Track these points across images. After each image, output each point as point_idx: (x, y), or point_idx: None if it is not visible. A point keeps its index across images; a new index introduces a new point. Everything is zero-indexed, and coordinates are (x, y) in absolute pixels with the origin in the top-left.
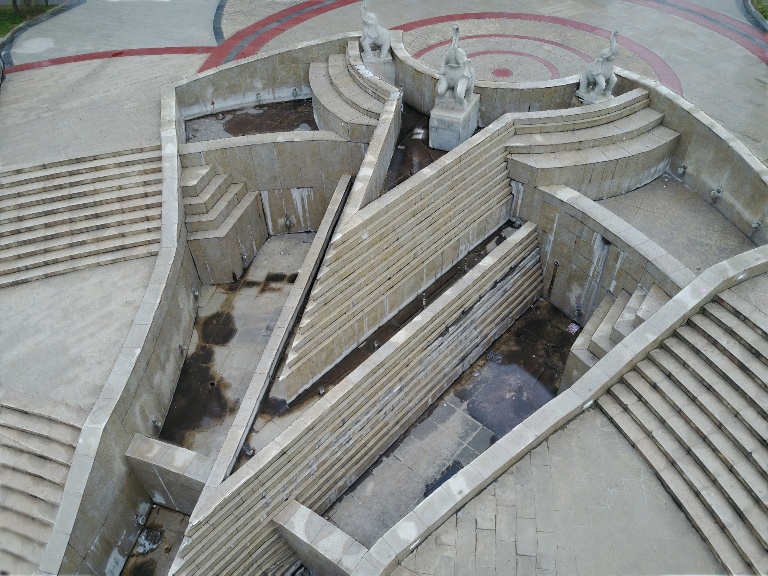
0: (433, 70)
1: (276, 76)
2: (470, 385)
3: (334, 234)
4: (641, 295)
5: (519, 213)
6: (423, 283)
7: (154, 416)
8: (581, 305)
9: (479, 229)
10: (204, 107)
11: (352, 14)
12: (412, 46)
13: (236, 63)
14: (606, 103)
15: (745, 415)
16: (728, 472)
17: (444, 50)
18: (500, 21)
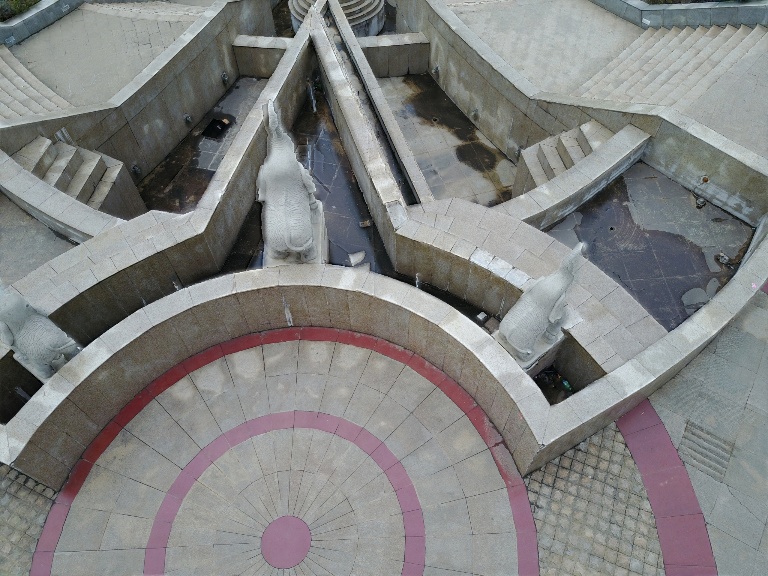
0: (368, 289)
1: None
2: None
3: None
4: None
5: None
6: None
7: None
8: None
9: None
10: None
11: None
12: None
13: (766, 249)
14: None
15: None
16: (7, 92)
17: None
18: None
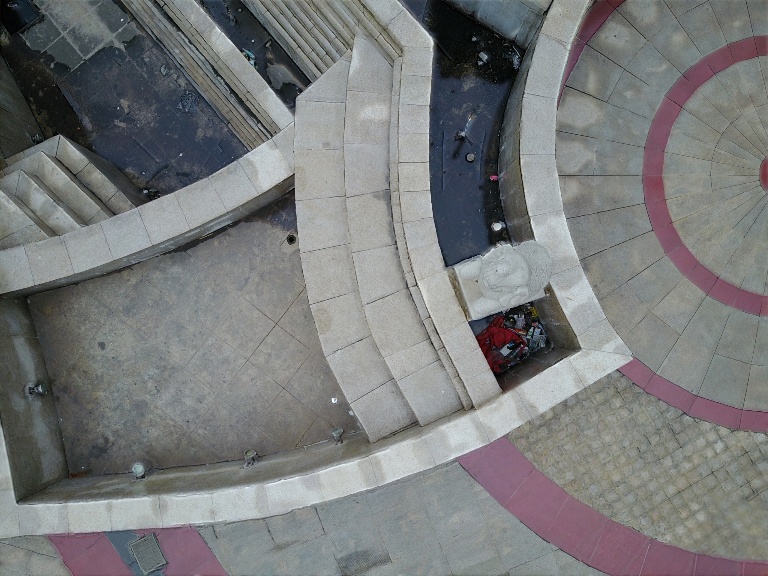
0: None
1: None
2: (148, 58)
3: None
4: None
5: None
6: None
7: None
8: None
9: None
10: None
11: None
12: None
13: None
14: (438, 282)
15: None
16: None
17: None
18: None
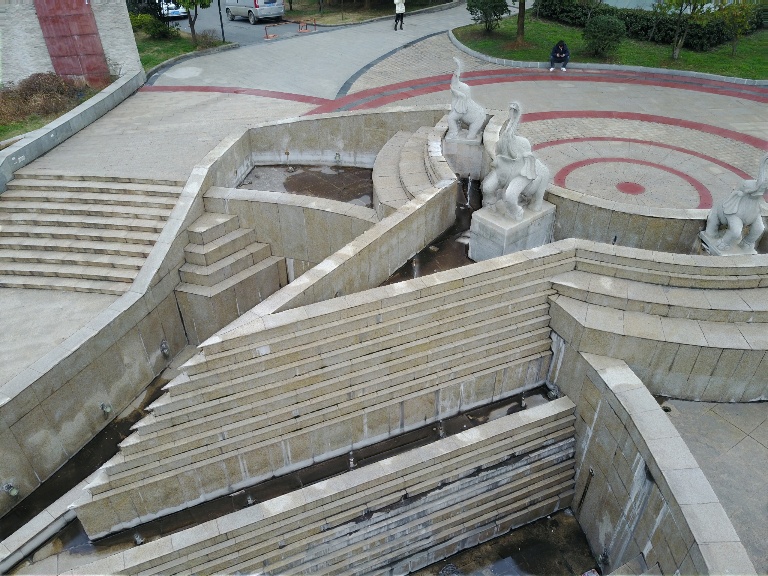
0: None
1: (360, 138)
2: None
3: (212, 336)
4: None
5: (557, 380)
6: (364, 436)
7: (15, 480)
8: (609, 550)
9: (481, 385)
10: (278, 156)
11: (495, 92)
12: (537, 136)
13: (319, 116)
14: (736, 259)
15: None
16: None
17: (573, 147)
18: (669, 128)
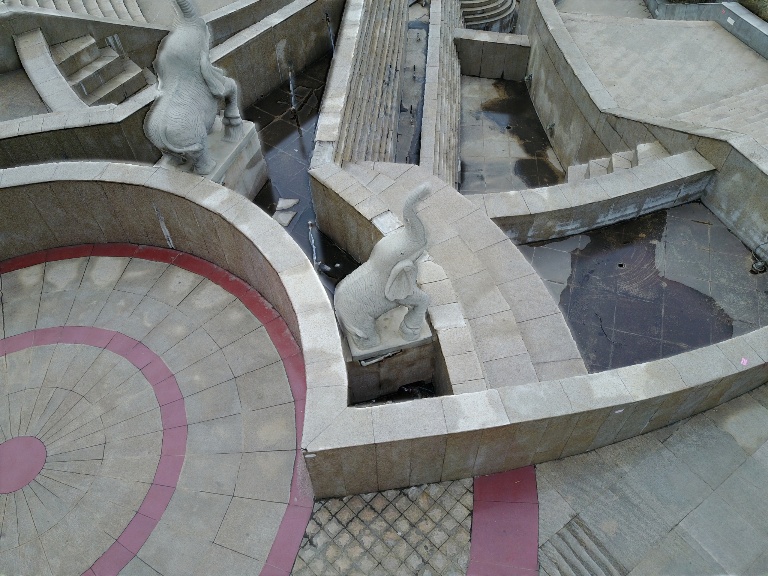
0: (229, 214)
1: None
2: None
3: None
4: (71, 80)
5: None
6: None
7: None
8: None
9: None
10: None
11: None
12: None
13: None
14: None
15: (65, 1)
16: (99, 2)
17: None
18: None
